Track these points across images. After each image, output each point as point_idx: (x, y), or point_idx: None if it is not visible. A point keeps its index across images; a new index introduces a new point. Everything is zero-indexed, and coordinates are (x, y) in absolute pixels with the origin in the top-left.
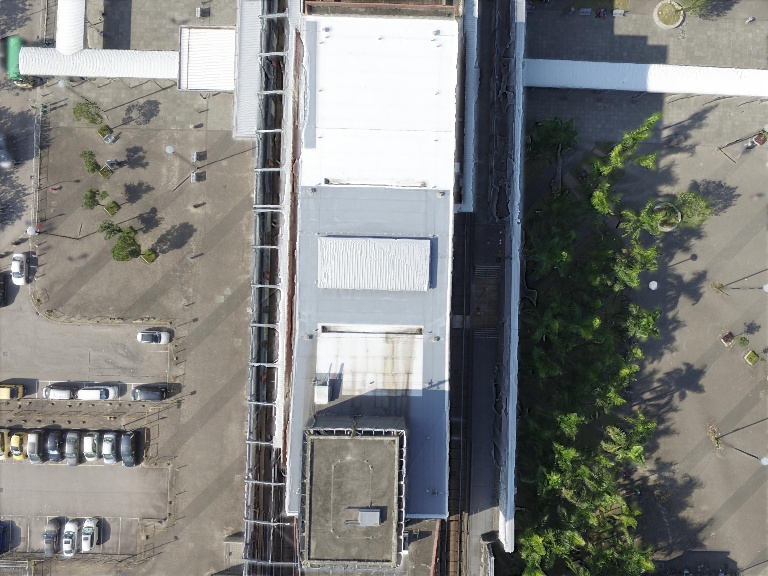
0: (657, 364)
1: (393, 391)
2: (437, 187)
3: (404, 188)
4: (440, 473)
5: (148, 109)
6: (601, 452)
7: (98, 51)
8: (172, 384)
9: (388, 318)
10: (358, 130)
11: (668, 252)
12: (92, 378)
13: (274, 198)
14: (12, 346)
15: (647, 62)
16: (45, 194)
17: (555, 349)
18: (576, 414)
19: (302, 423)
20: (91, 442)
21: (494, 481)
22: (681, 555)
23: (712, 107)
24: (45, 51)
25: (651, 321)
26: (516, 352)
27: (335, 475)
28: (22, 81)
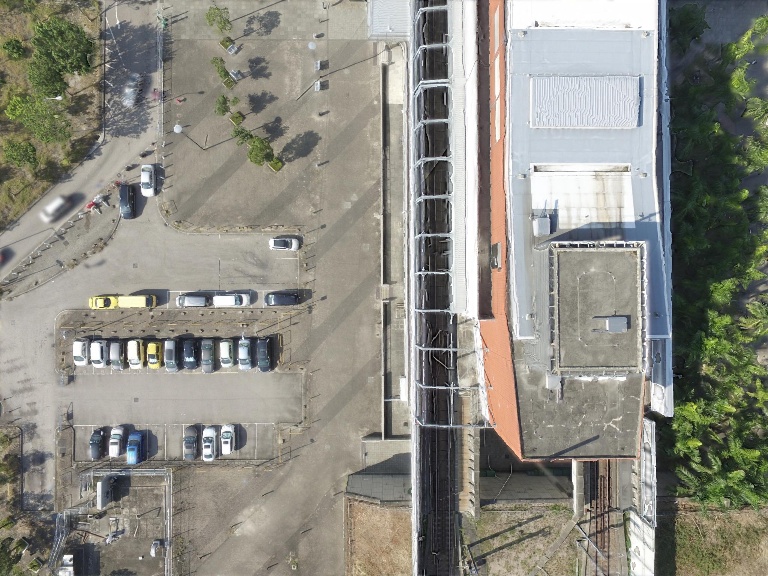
0: None
1: (607, 224)
2: (642, 28)
3: (611, 29)
4: (659, 297)
5: (269, 20)
6: None
7: None
8: (303, 290)
9: (597, 156)
10: None
11: None
12: (223, 287)
13: None
14: (142, 258)
15: None
16: (169, 106)
17: (699, 226)
18: (732, 279)
19: (524, 255)
20: (228, 347)
21: None
22: None
23: None
24: None
25: None
26: (669, 224)
27: (580, 287)
28: None
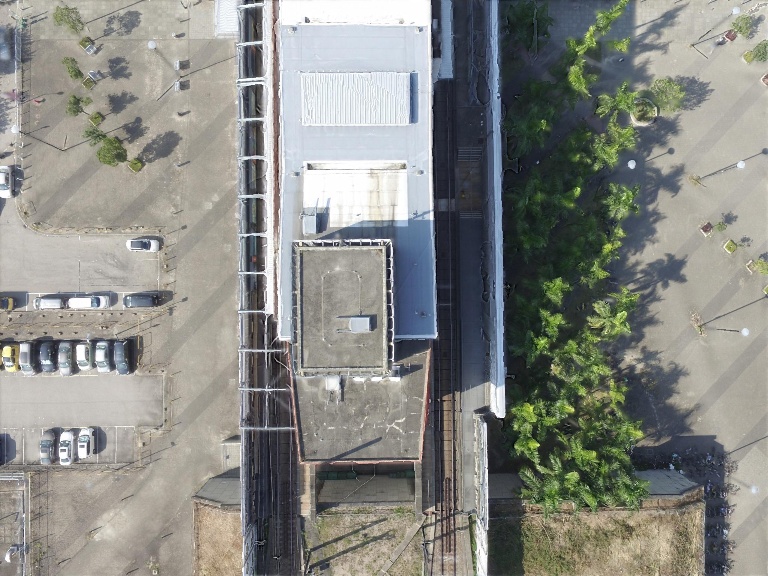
0: (640, 255)
1: (379, 222)
2: (415, 23)
3: (383, 25)
4: (428, 296)
5: (129, 20)
6: (587, 329)
7: None
8: (163, 292)
9: (372, 154)
10: None
11: (646, 146)
12: (82, 289)
13: (258, 84)
14: (0, 260)
15: None
16: (28, 107)
17: (539, 224)
18: (561, 278)
19: None
20: (84, 350)
21: (484, 358)
22: (669, 440)
23: (683, 5)
24: None
25: (630, 194)
26: (500, 222)
27: (325, 286)
28: None
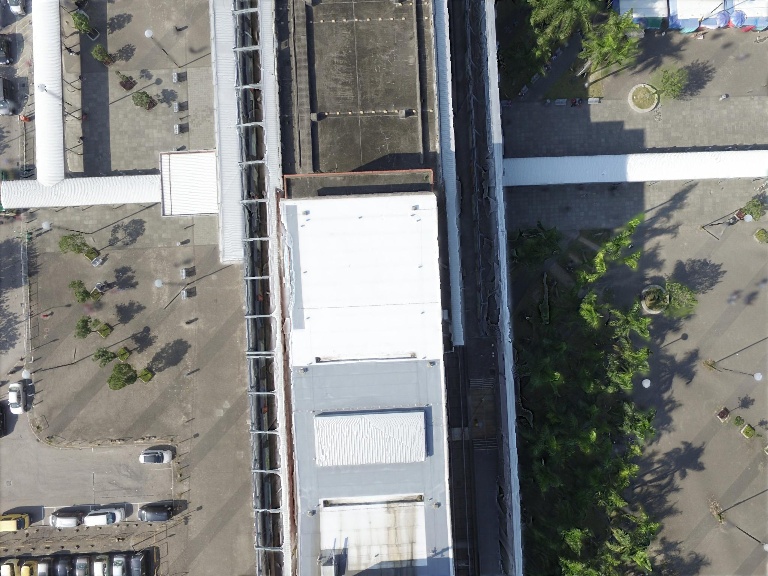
0: (656, 445)
1: (398, 562)
2: (427, 357)
3: (395, 361)
4: None
5: (134, 228)
6: (607, 550)
7: (79, 180)
8: (178, 501)
9: (388, 488)
10: (345, 308)
11: (659, 333)
12: (97, 501)
13: (266, 330)
14: (15, 475)
15: (625, 146)
16: (37, 321)
17: (554, 459)
18: (579, 530)
19: None
20: (101, 567)
21: None
22: None
23: (692, 186)
24: (26, 184)
25: (647, 423)
26: (516, 471)
27: None
28: (5, 212)
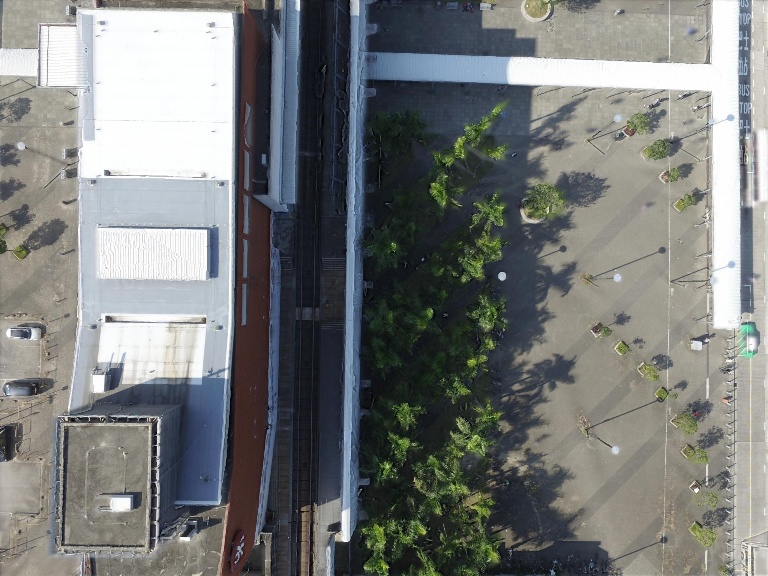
0: (526, 355)
1: (173, 380)
2: (216, 177)
3: (183, 179)
4: (215, 460)
5: (19, 107)
6: (453, 442)
7: None
8: (44, 379)
9: (171, 308)
10: (136, 122)
11: (537, 244)
12: None
13: None
14: None
15: (515, 55)
16: None
17: (398, 340)
18: (407, 404)
19: None
20: None
21: (341, 472)
22: (552, 545)
23: (581, 99)
24: None
25: (494, 311)
26: (351, 343)
27: (89, 462)
28: None
